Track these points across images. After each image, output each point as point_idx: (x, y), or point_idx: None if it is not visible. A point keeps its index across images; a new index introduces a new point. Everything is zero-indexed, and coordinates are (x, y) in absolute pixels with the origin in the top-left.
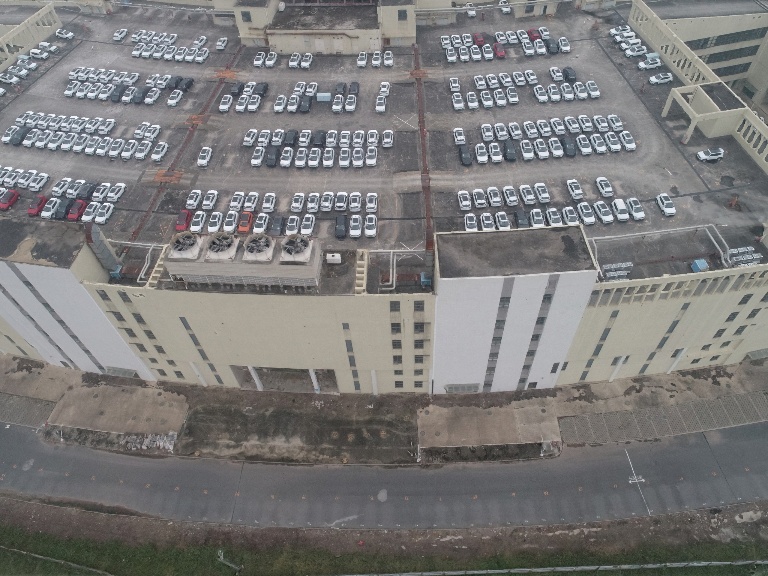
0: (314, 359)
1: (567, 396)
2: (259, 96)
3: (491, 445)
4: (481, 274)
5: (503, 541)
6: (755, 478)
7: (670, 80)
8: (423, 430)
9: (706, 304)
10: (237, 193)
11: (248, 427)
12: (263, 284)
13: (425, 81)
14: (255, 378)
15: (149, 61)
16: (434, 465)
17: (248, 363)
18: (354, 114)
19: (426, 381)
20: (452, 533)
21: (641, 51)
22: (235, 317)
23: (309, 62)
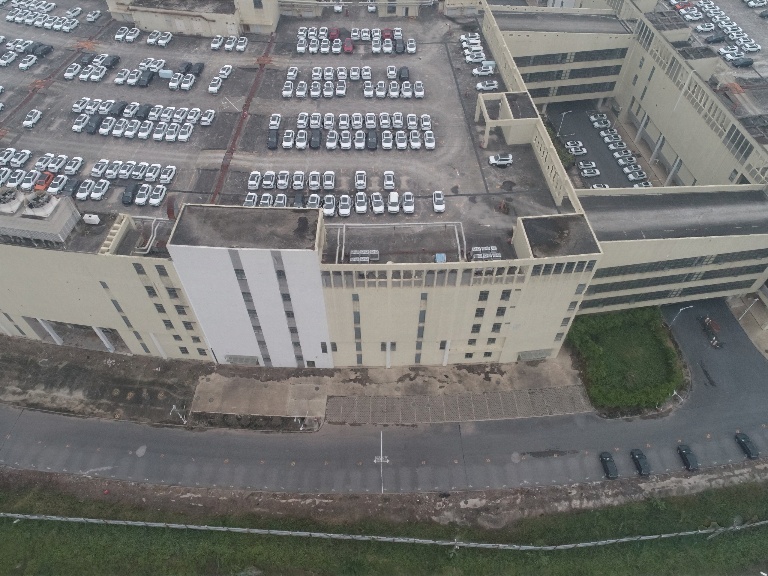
0: (92, 316)
1: (343, 377)
2: (105, 67)
3: (257, 415)
4: (209, 244)
5: (237, 503)
6: (492, 469)
7: (495, 88)
8: (199, 395)
9: (445, 296)
10: (47, 154)
11: (38, 377)
12: (15, 236)
13: (268, 68)
14: (49, 331)
15: (21, 26)
16: (198, 428)
17: (36, 315)
18: (188, 92)
19: (207, 349)
20: (193, 491)
21: (480, 58)
22: (1, 266)
23: (166, 40)
